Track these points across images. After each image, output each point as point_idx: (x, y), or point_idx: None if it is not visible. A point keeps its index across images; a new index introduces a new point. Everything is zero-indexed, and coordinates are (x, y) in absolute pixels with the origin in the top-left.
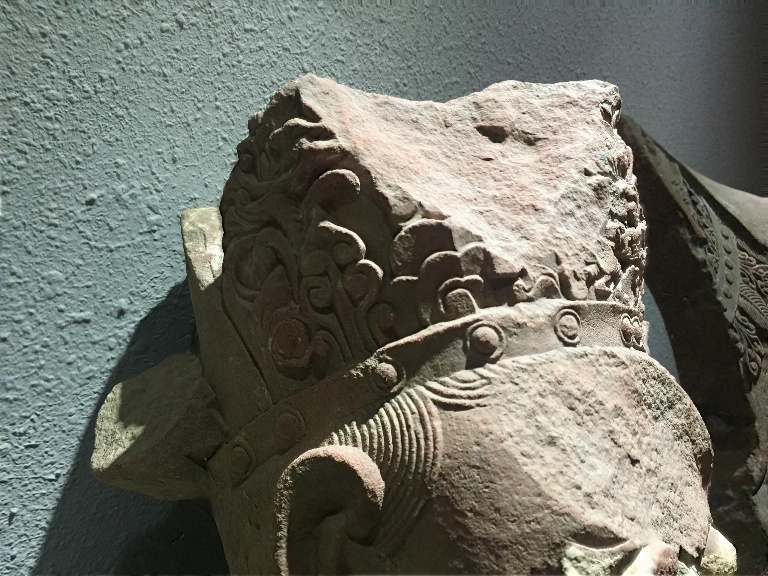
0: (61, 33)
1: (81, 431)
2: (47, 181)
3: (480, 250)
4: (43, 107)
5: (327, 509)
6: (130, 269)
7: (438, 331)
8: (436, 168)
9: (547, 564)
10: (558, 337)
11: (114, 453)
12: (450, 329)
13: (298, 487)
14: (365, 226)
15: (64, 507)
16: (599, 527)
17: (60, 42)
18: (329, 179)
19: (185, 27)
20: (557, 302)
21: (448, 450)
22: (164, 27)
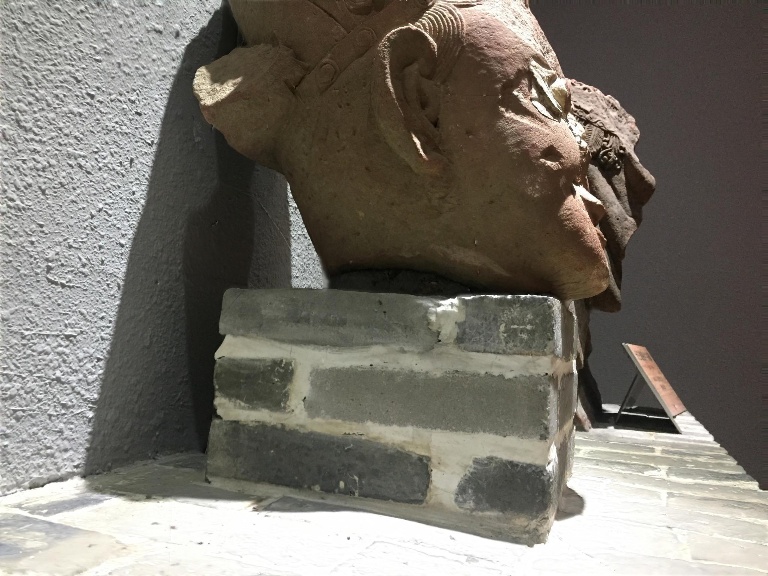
0: None
1: (162, 115)
2: None
3: None
4: None
5: (406, 63)
6: (179, 4)
7: None
8: None
9: (524, 68)
10: None
11: (224, 93)
12: None
13: (393, 46)
14: None
15: (156, 169)
16: (542, 56)
17: None
18: None
19: None
20: None
21: (468, 23)
22: None
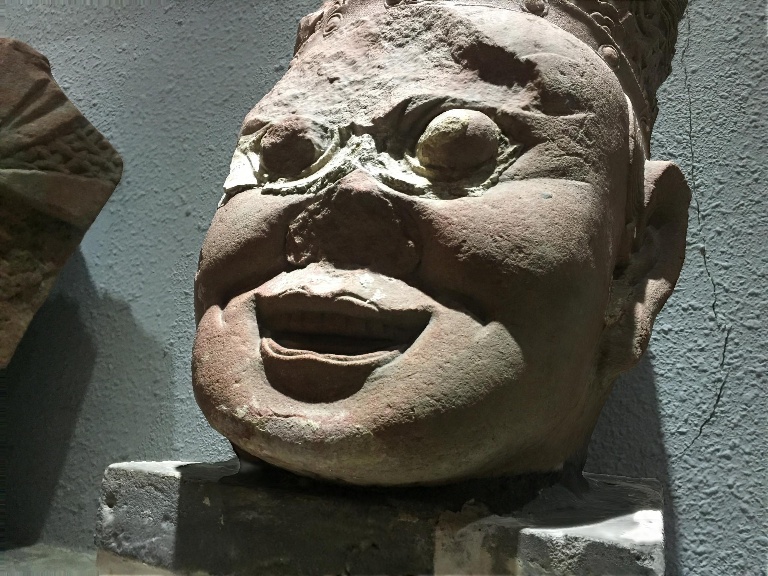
0: None
1: None
2: None
3: None
4: None
5: None
6: None
7: None
8: None
9: None
10: None
11: None
12: None
13: None
14: None
15: None
16: None
17: None
18: None
19: None
20: None
21: None
22: None
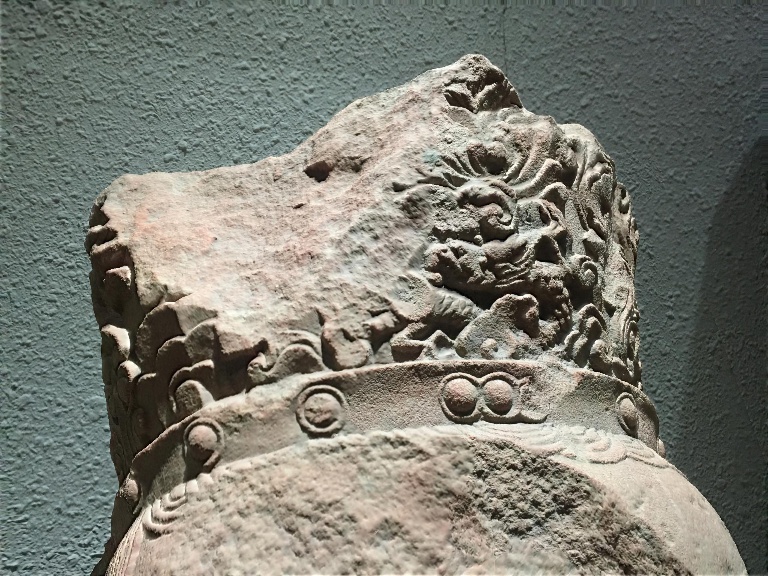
0: (71, 195)
1: None
2: (78, 320)
3: (208, 328)
4: (65, 260)
5: None
6: None
7: (161, 437)
8: (230, 235)
9: None
10: (301, 427)
11: None
12: (170, 433)
13: None
14: (135, 323)
15: None
16: None
17: (72, 202)
18: (107, 280)
19: (189, 150)
20: (307, 378)
21: None
22: (167, 158)
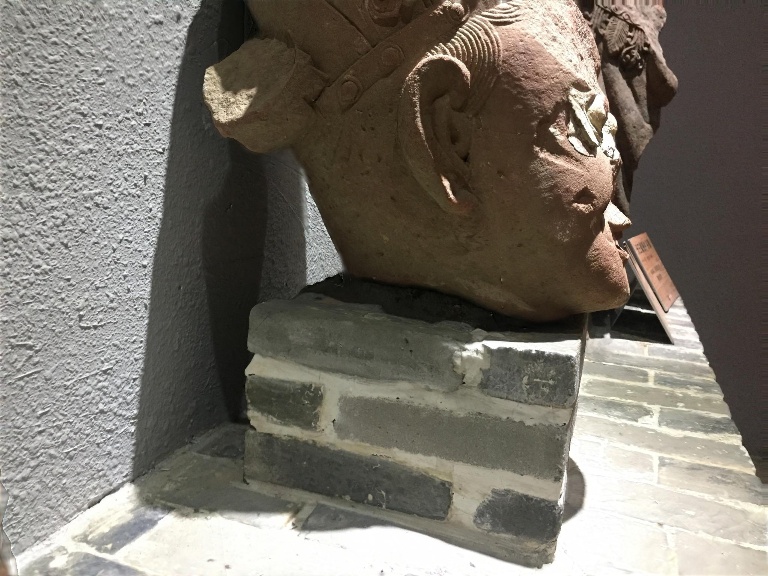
0: None
1: (170, 116)
2: None
3: None
4: None
5: (436, 95)
6: None
7: None
8: None
9: (562, 99)
10: None
11: (239, 109)
12: None
13: (423, 80)
14: None
15: (170, 175)
16: (582, 80)
17: None
18: None
19: None
20: None
21: (505, 47)
22: None
